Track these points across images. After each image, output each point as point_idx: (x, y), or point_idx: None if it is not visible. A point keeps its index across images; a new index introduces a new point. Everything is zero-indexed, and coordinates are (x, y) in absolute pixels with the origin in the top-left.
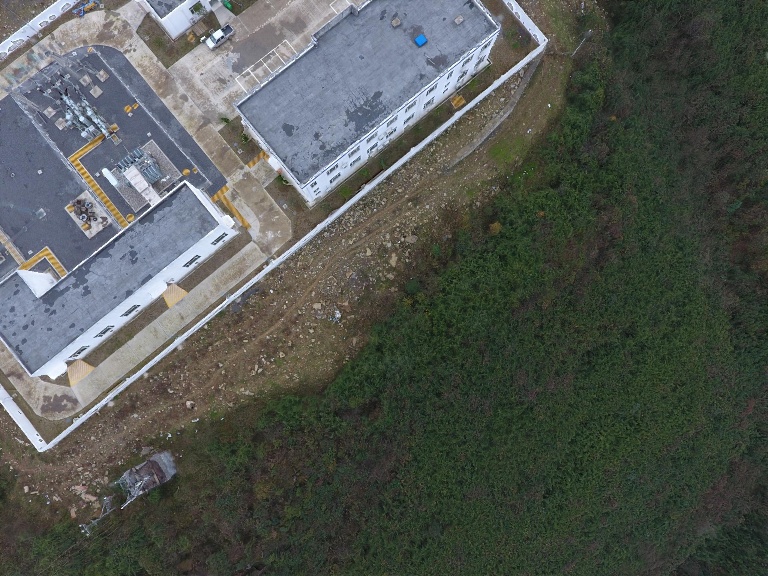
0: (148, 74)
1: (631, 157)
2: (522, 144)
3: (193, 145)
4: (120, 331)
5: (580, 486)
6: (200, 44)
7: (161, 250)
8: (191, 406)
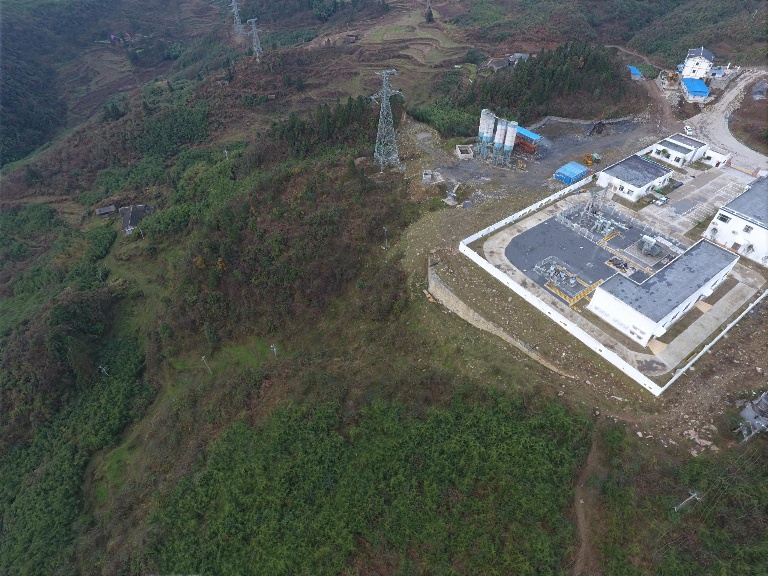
0: None
1: None
2: None
3: None
4: (675, 324)
5: None
6: (650, 204)
7: (707, 267)
8: (761, 372)
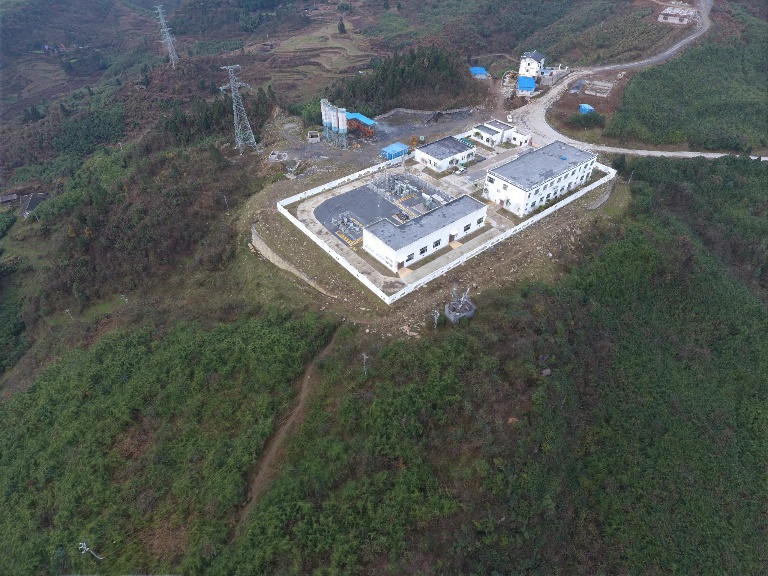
0: (429, 181)
1: None
2: (619, 209)
3: None
4: (427, 257)
5: (765, 449)
6: (452, 174)
7: (458, 214)
8: (476, 286)
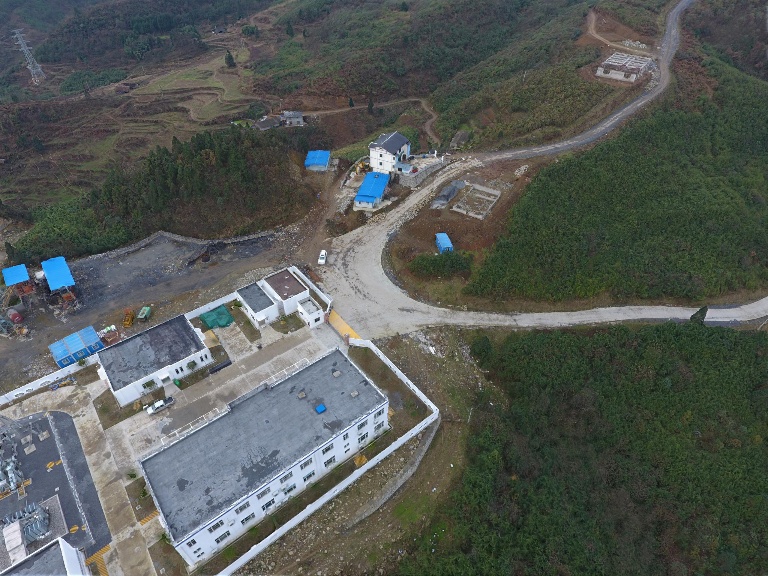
0: (85, 434)
1: (550, 519)
2: (428, 503)
3: (95, 500)
4: None
5: None
6: (142, 411)
7: None
8: None
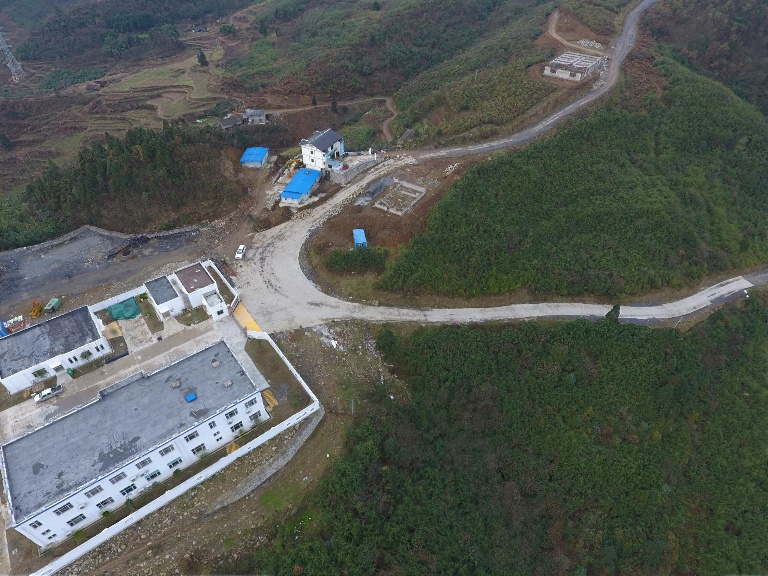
0: None
1: (425, 510)
2: (296, 491)
3: None
4: None
5: None
6: (31, 399)
7: None
8: None
